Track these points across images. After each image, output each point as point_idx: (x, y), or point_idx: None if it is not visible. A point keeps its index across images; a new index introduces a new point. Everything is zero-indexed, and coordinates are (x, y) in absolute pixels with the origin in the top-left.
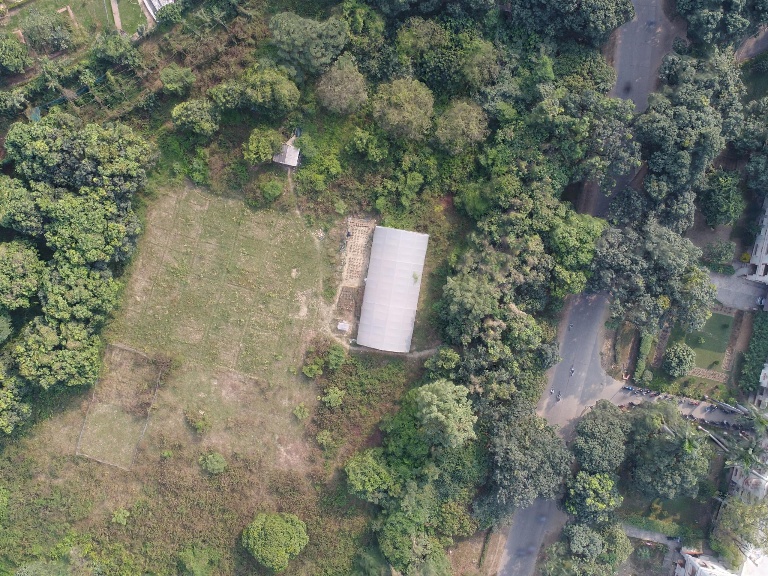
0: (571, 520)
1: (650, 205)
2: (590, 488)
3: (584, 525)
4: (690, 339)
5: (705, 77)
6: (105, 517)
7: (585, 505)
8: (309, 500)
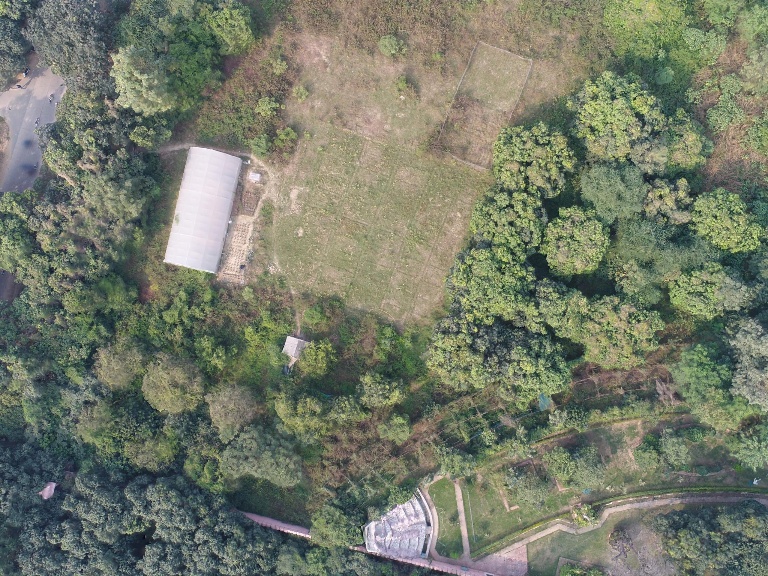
0: None
1: None
2: (5, 1)
3: None
4: None
5: None
6: None
7: None
8: (300, 5)
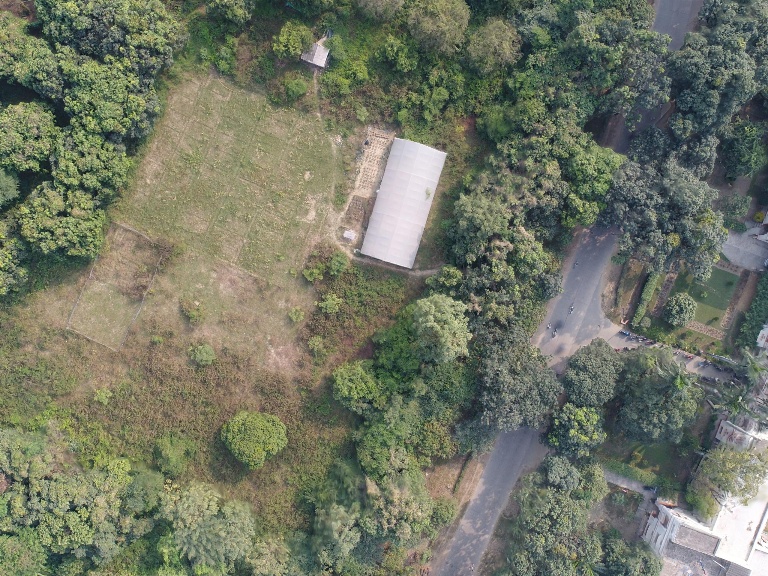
0: (552, 452)
1: (672, 145)
2: (575, 419)
3: (564, 457)
4: (693, 292)
5: (745, 20)
6: (87, 395)
7: (568, 436)
8: (293, 404)
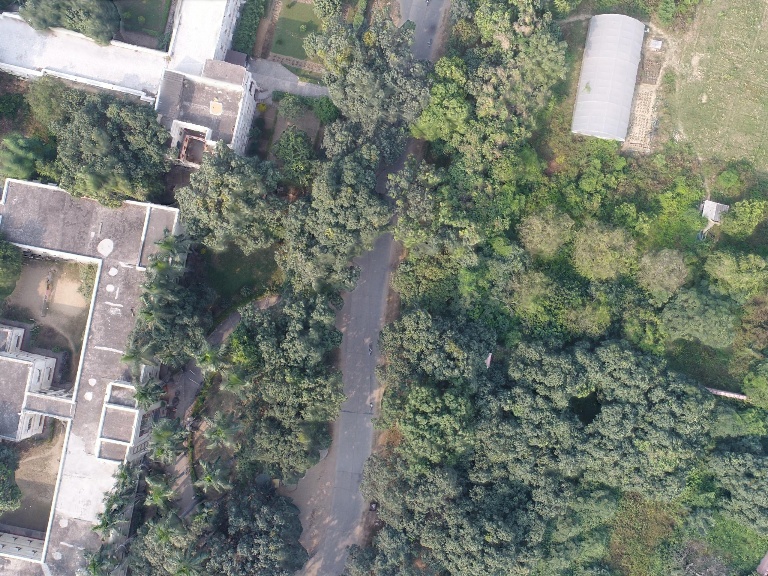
0: None
1: None
2: None
3: None
4: (314, 31)
5: (327, 258)
6: None
7: None
8: None
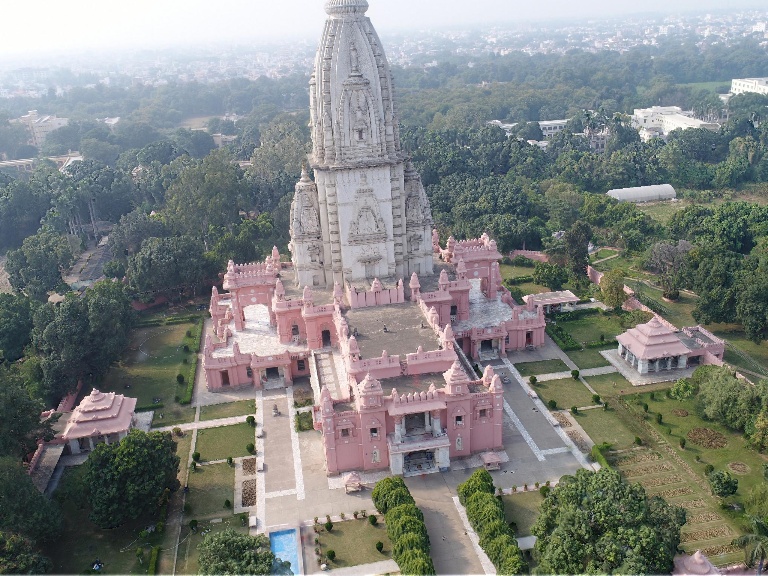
0: None
1: None
2: None
3: None
4: None
5: None
6: None
7: None
8: None
